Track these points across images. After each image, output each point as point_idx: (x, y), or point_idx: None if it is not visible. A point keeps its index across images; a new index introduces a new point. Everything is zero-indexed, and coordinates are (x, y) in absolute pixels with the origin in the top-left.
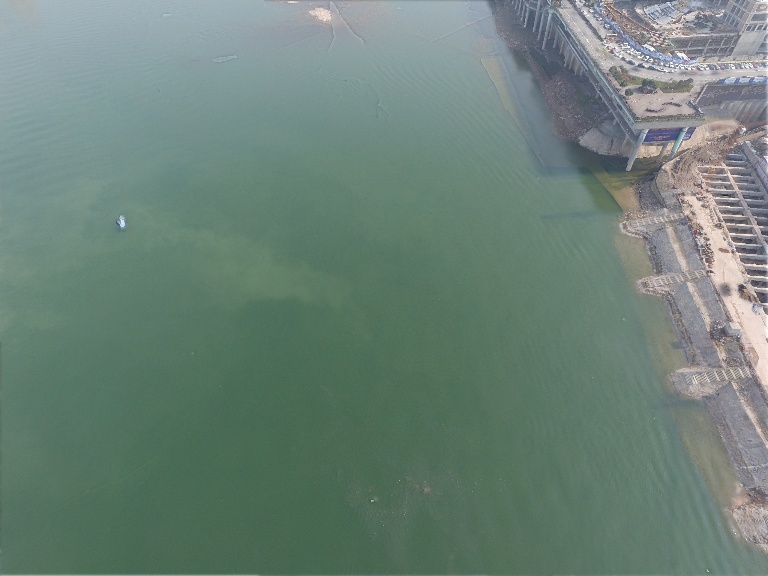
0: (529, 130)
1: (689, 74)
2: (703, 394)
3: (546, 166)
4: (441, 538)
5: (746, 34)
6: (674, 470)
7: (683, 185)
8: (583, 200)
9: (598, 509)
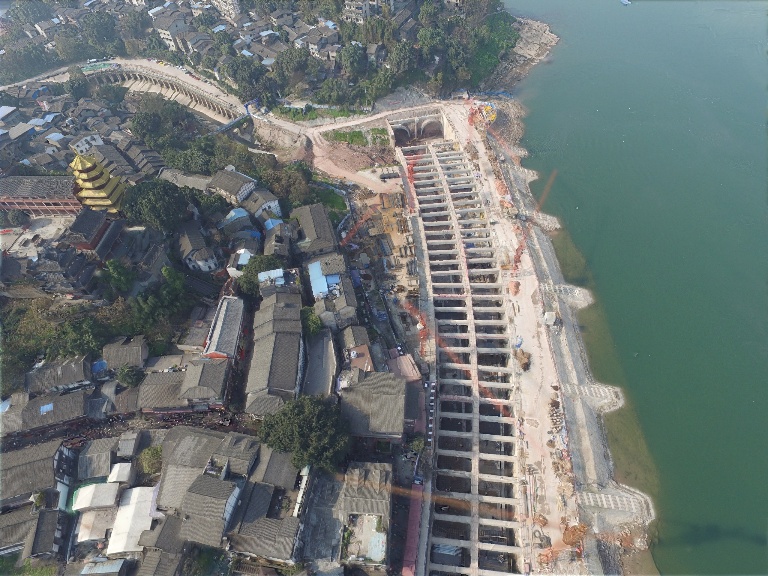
0: None
1: None
2: None
3: None
4: (734, 210)
5: None
6: (594, 244)
7: None
8: None
9: (644, 223)
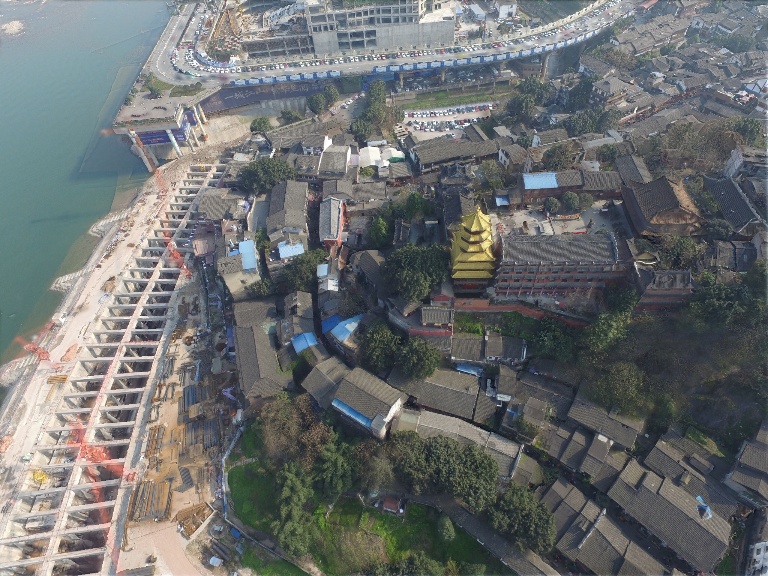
0: (98, 137)
1: (217, 77)
2: (9, 381)
3: (81, 172)
4: None
5: (316, 35)
6: None
7: (158, 184)
8: (85, 203)
9: None
